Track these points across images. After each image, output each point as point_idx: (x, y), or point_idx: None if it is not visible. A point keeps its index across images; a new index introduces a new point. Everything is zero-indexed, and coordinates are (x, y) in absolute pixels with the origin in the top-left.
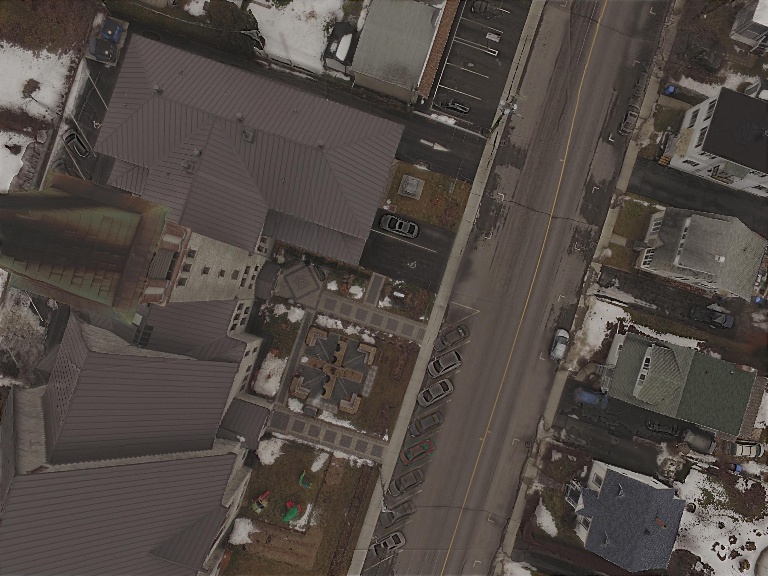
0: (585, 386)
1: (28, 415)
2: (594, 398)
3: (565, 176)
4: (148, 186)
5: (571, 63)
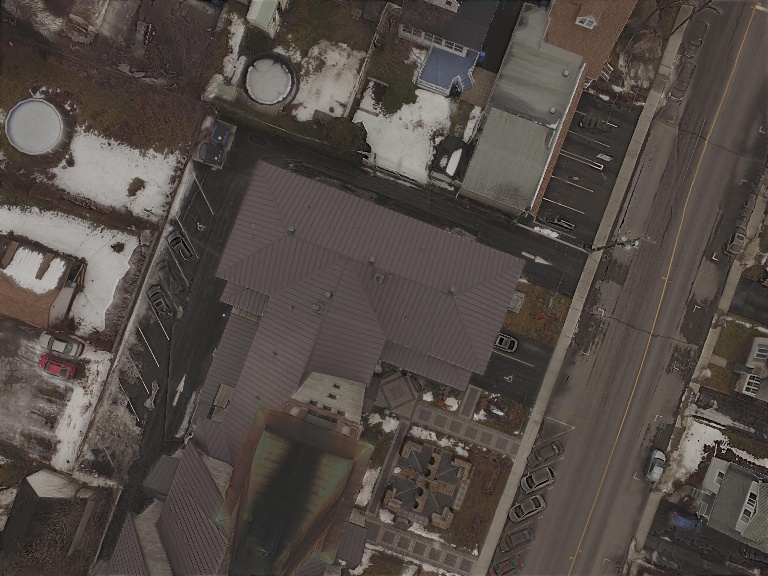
0: (679, 509)
1: (153, 557)
2: (690, 524)
3: (667, 294)
4: (268, 314)
5: (677, 180)
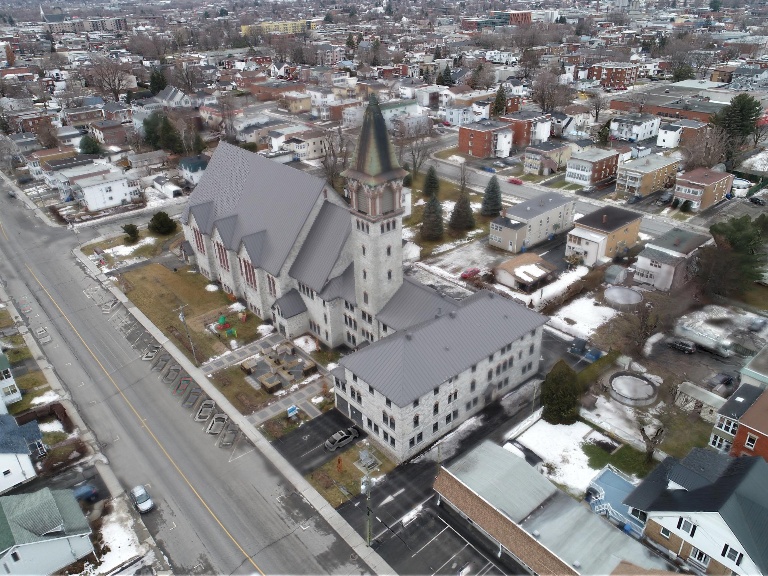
0: (89, 501)
1: None
2: (76, 495)
3: None
4: None
5: None
